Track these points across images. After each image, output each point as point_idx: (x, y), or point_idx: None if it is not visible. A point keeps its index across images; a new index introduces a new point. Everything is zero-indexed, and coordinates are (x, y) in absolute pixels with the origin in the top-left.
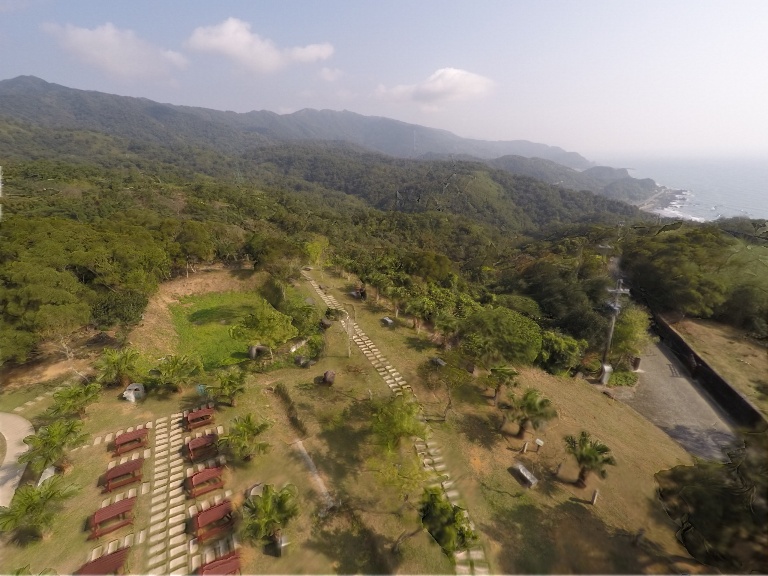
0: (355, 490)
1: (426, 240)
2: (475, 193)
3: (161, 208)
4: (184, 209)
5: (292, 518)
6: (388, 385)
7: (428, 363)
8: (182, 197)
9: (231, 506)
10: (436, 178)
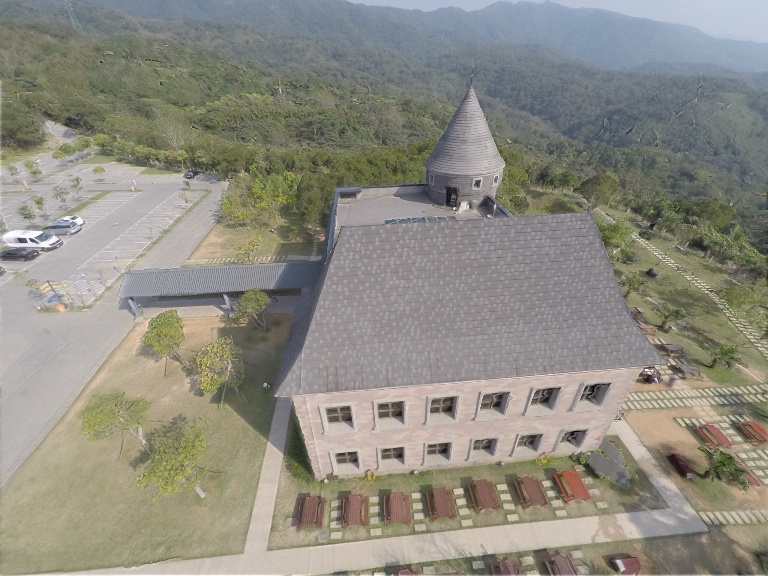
0: (695, 324)
1: (631, 181)
2: (719, 128)
3: (388, 121)
4: (405, 124)
5: (686, 317)
6: (696, 286)
7: (722, 281)
8: (397, 111)
9: (635, 309)
10: (665, 103)
